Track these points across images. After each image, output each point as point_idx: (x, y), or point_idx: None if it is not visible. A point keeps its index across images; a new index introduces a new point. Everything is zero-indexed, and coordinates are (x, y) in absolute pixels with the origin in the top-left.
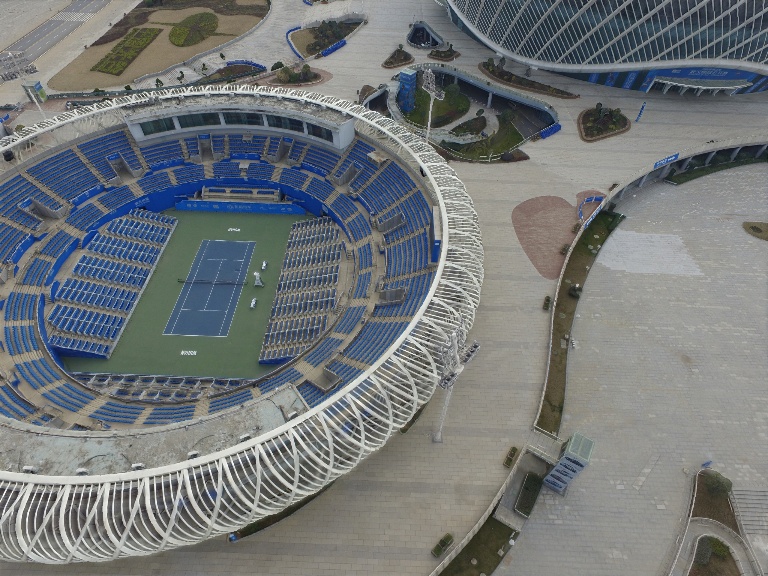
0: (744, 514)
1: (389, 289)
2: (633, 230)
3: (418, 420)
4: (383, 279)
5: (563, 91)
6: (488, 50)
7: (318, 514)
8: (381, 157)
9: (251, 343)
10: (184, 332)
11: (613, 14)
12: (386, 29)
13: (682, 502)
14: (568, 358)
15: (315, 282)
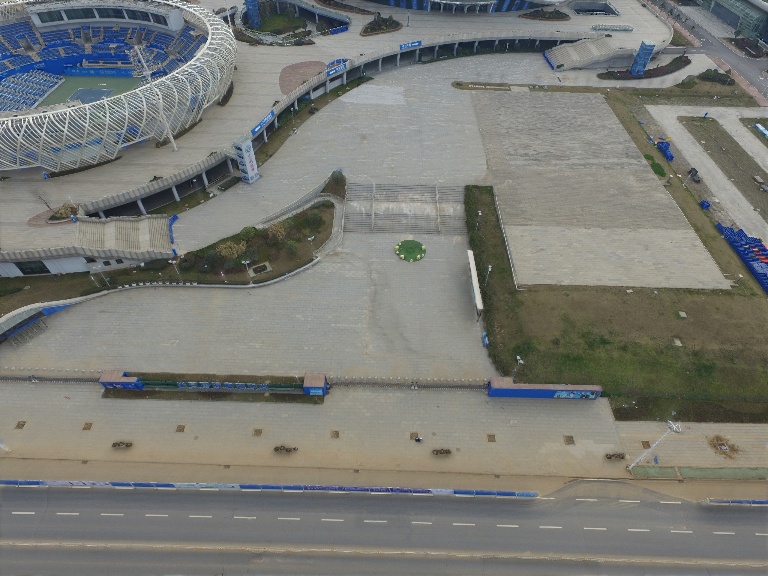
0: (352, 193)
1: None
2: (374, 85)
3: (169, 144)
4: None
5: (365, 10)
6: None
7: (96, 172)
8: (197, 33)
9: None
10: None
11: None
12: None
13: (317, 187)
14: (289, 137)
15: None
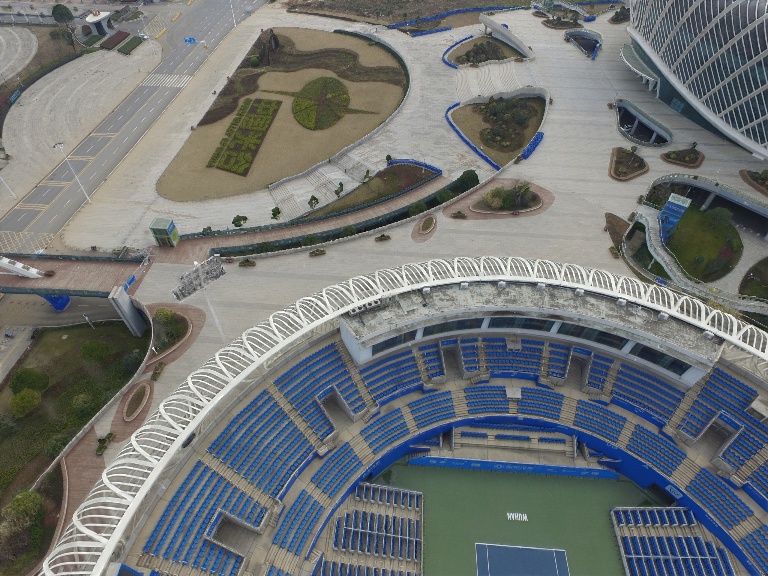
0: None
1: None
2: None
3: None
4: None
5: None
6: (736, 148)
7: None
8: None
9: None
10: None
11: None
12: (581, 112)
13: None
14: None
15: None
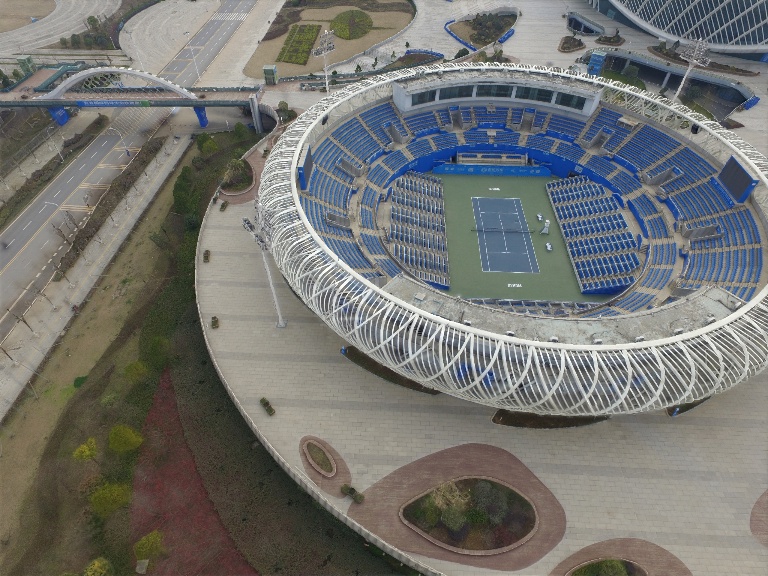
0: None
1: (699, 227)
2: None
3: None
4: (680, 221)
5: (742, 69)
6: (648, 36)
7: (732, 398)
8: (633, 121)
9: (565, 278)
10: (500, 269)
11: None
12: (542, 20)
13: None
14: None
15: (603, 228)
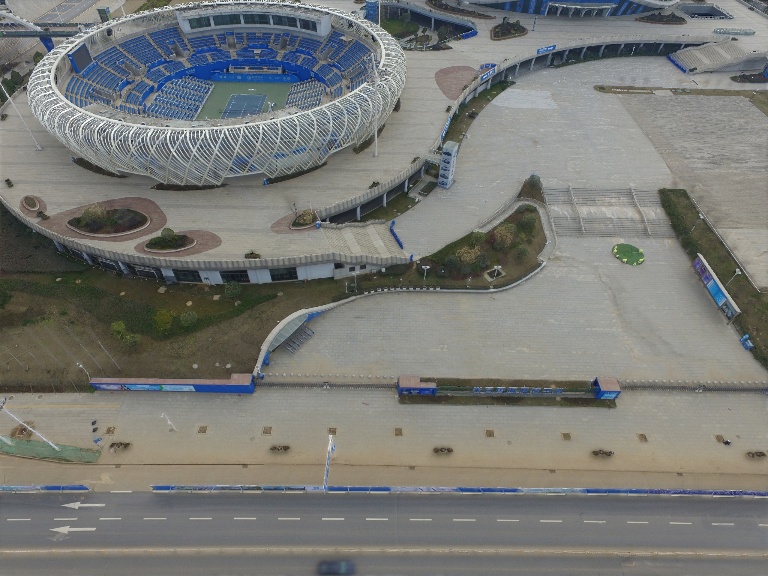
0: (549, 197)
1: None
2: (519, 89)
3: (366, 150)
4: None
5: (484, 14)
6: None
7: (310, 178)
8: (349, 38)
9: None
10: None
11: None
12: None
13: (514, 191)
14: (462, 142)
15: (307, 107)
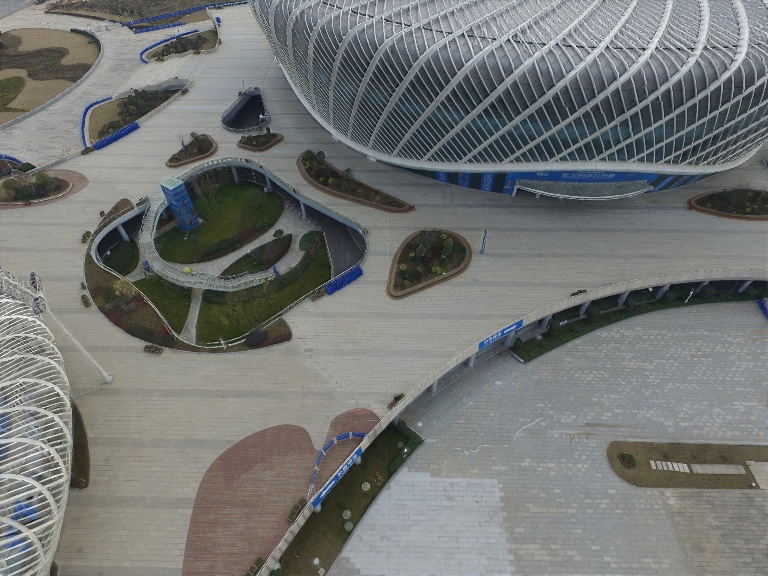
0: None
1: None
2: (427, 471)
3: None
4: None
5: (393, 200)
6: (324, 130)
7: None
8: None
9: None
10: None
11: (431, 106)
12: (206, 101)
13: None
14: None
15: None
